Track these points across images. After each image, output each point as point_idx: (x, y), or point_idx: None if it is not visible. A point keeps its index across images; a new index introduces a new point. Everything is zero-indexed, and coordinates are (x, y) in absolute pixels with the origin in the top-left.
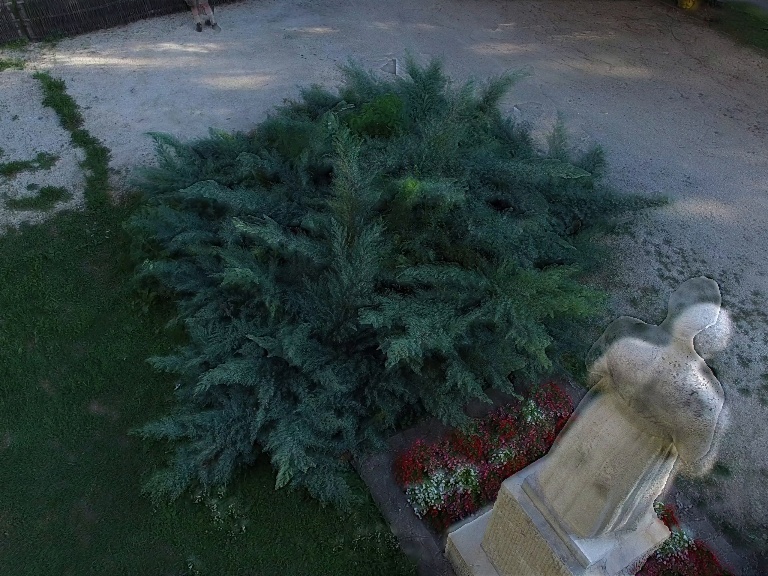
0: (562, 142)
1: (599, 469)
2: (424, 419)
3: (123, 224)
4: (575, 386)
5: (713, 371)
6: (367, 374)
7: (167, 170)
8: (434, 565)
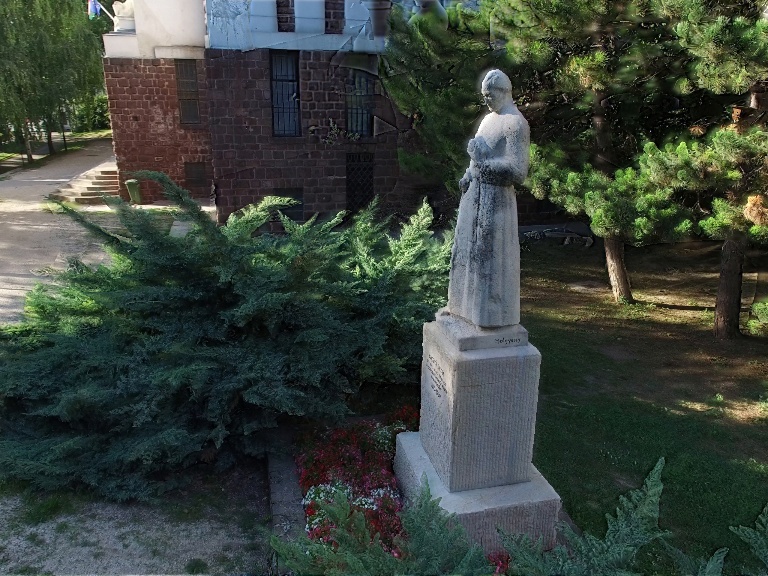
0: None
1: None
2: None
3: None
4: None
5: None
6: None
7: None
8: None
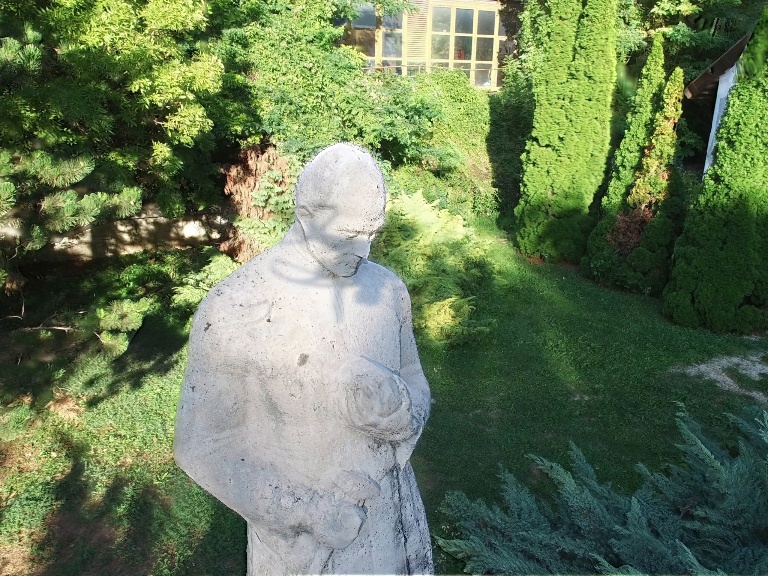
0: None
1: None
2: None
3: (736, 400)
4: None
5: None
6: None
7: None
8: None
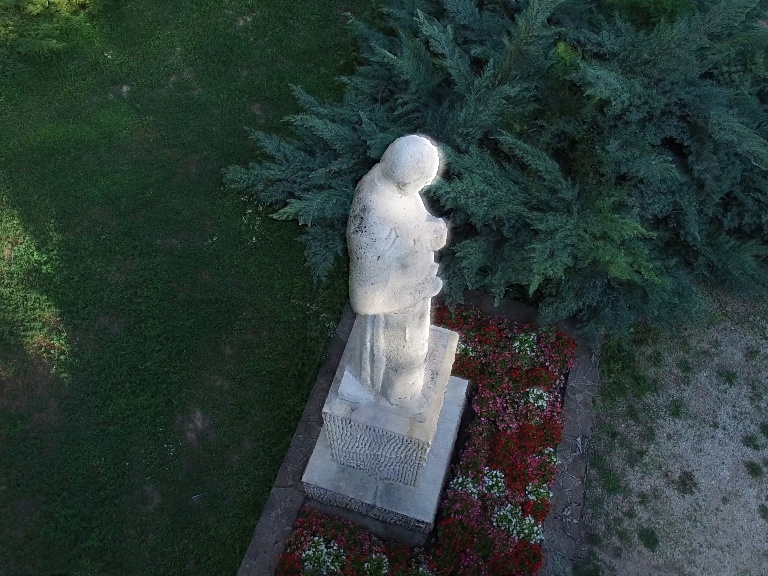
0: None
1: None
2: None
3: None
4: (594, 361)
5: (756, 469)
6: None
7: None
8: None
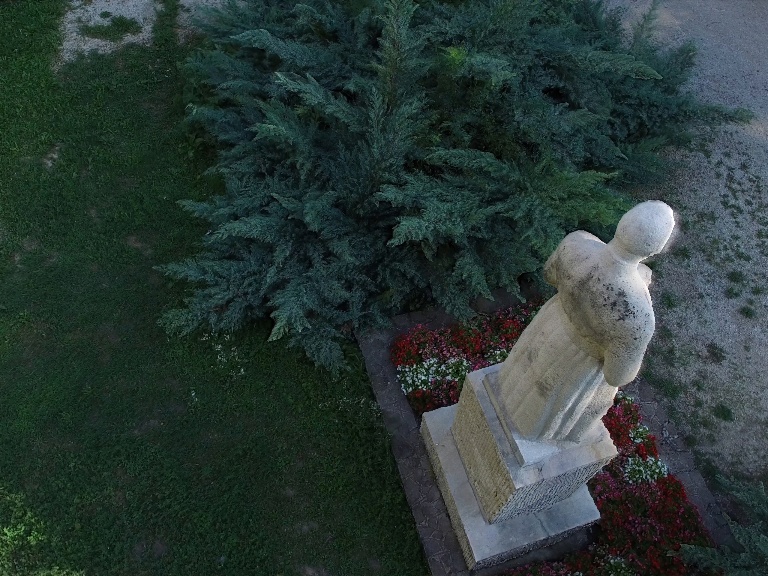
0: (650, 37)
1: (541, 378)
2: (433, 304)
3: (178, 64)
4: None
5: (749, 311)
6: (384, 251)
7: (228, 14)
8: (409, 437)
